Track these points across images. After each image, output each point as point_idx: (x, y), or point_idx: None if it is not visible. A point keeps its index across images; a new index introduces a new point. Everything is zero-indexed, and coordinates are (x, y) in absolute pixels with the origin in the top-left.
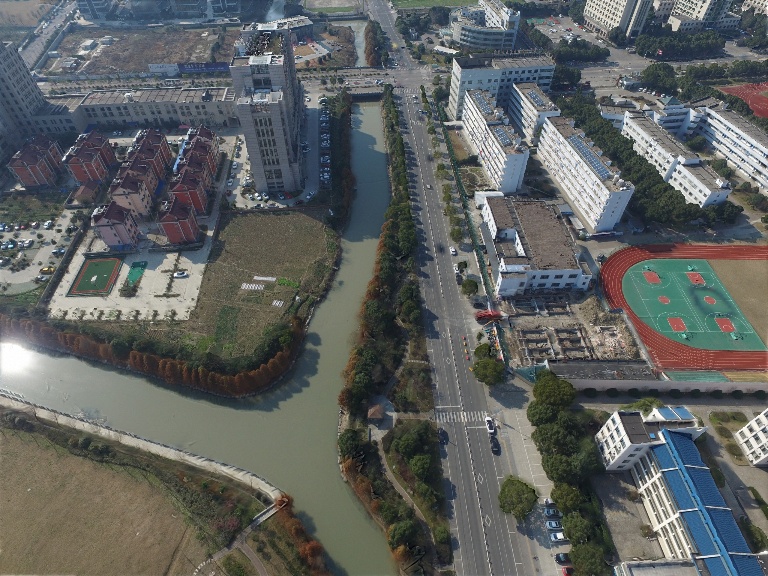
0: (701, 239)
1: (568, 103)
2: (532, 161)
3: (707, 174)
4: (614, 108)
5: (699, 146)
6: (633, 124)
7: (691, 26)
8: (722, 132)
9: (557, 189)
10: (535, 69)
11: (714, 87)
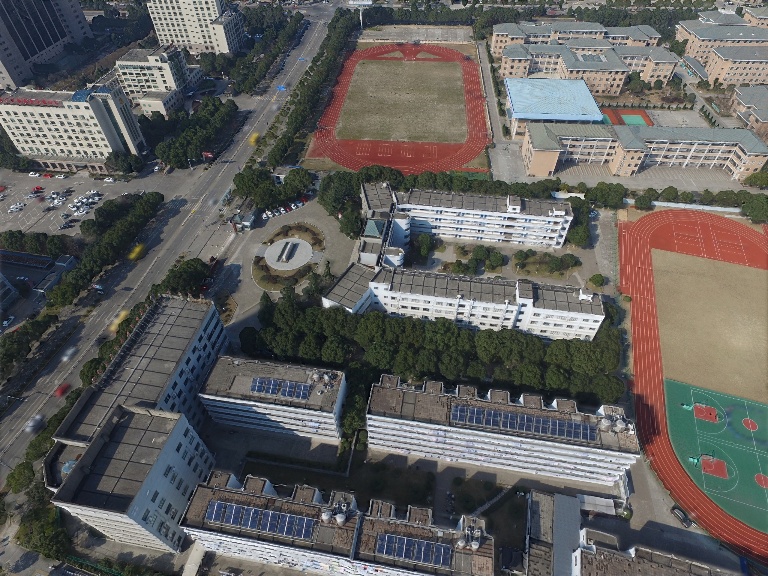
0: (621, 357)
1: (287, 331)
2: (389, 469)
3: (556, 294)
4: (341, 286)
5: (432, 246)
6: (409, 296)
7: (173, 100)
8: (435, 218)
9: (483, 474)
10: (197, 339)
11: (303, 159)
